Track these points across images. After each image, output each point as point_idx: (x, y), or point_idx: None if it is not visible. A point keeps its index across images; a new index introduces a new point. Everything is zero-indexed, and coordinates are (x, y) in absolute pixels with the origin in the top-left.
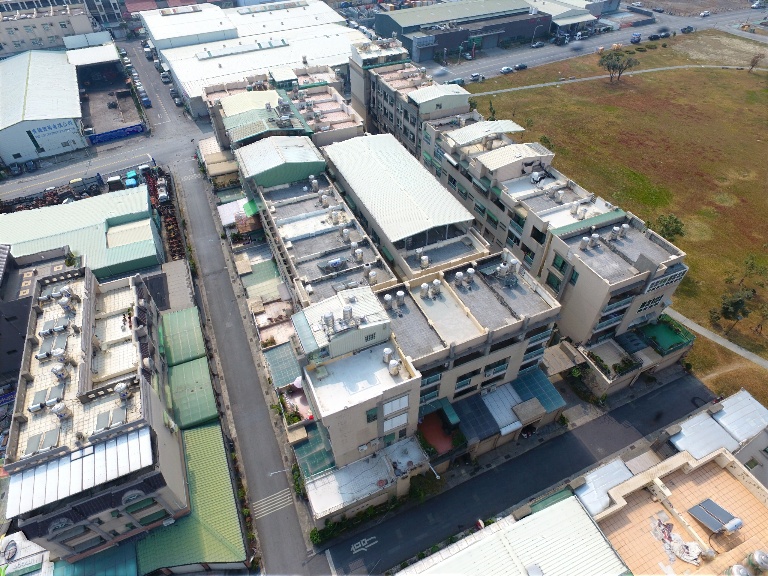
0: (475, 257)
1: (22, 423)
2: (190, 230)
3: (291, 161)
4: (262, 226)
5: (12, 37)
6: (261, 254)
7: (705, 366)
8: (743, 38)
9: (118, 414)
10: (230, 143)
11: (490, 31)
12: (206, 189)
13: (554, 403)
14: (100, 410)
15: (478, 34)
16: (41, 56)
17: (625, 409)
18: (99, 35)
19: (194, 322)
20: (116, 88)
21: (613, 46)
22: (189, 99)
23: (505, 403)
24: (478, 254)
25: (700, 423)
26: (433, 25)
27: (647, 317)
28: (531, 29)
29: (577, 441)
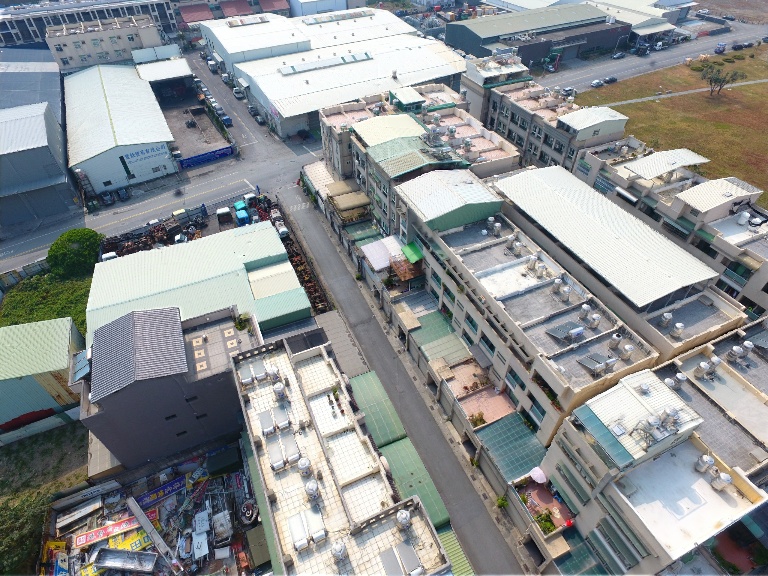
0: (731, 323)
1: (288, 567)
2: (319, 270)
3: (472, 202)
4: (424, 272)
5: (79, 51)
6: (423, 303)
7: None
8: None
9: (406, 553)
10: (351, 171)
11: (573, 42)
12: (321, 221)
13: None
14: (378, 546)
15: (561, 45)
16: (111, 71)
17: None
18: (168, 48)
19: (380, 393)
20: (189, 105)
21: (700, 57)
22: (280, 118)
23: None
24: (736, 319)
25: None
26: (512, 36)
27: None
28: (611, 39)
29: None
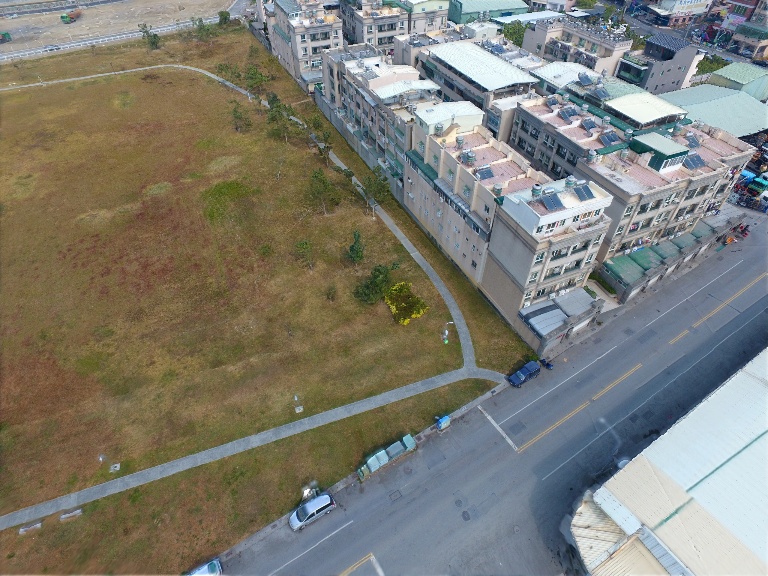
0: (426, 51)
1: None
2: None
3: None
4: None
5: None
6: None
7: None
8: None
9: None
10: None
11: None
12: None
13: None
14: None
15: None
16: None
17: None
18: None
19: None
20: None
21: None
22: None
23: None
24: (425, 50)
25: None
26: None
27: None
28: None
29: None
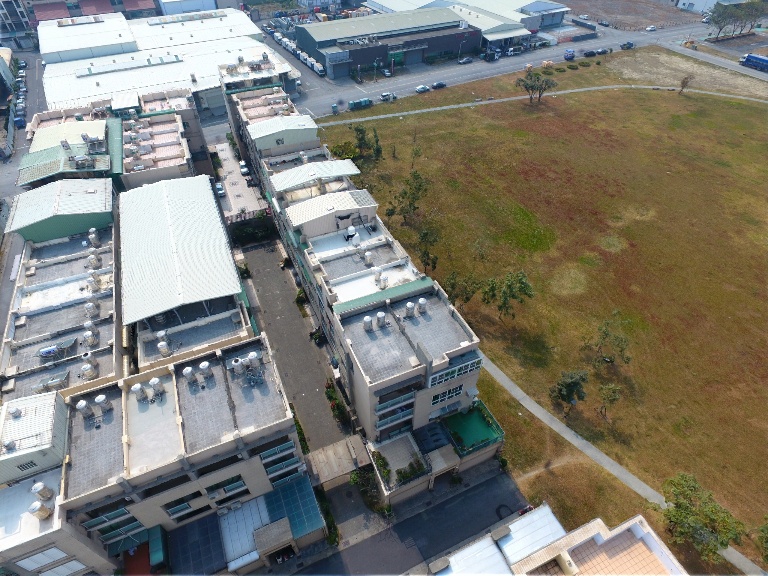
0: (230, 341)
1: None
2: (1, 278)
3: (64, 213)
4: None
5: None
6: None
7: (526, 461)
8: (683, 55)
9: None
10: None
11: (411, 46)
12: None
13: (308, 524)
14: None
15: (398, 49)
16: None
17: (414, 521)
18: None
19: None
20: None
21: (543, 63)
22: None
23: (248, 525)
24: (233, 338)
25: (477, 553)
26: (351, 39)
27: (449, 408)
28: None
29: (342, 567)
